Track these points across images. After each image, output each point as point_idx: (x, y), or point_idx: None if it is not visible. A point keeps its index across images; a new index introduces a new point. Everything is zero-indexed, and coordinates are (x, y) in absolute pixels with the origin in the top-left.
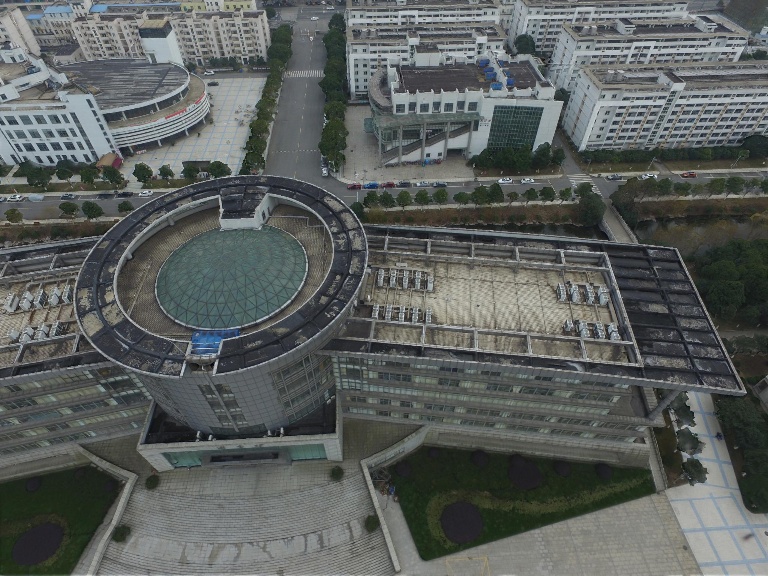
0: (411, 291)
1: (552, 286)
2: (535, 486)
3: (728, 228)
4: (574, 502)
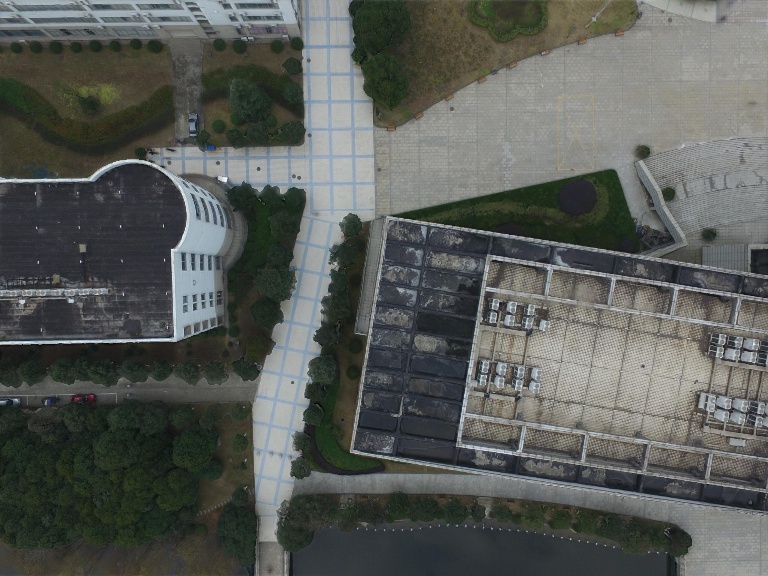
0: (729, 393)
1: (537, 397)
2: (502, 226)
3: (131, 572)
4: (469, 210)
